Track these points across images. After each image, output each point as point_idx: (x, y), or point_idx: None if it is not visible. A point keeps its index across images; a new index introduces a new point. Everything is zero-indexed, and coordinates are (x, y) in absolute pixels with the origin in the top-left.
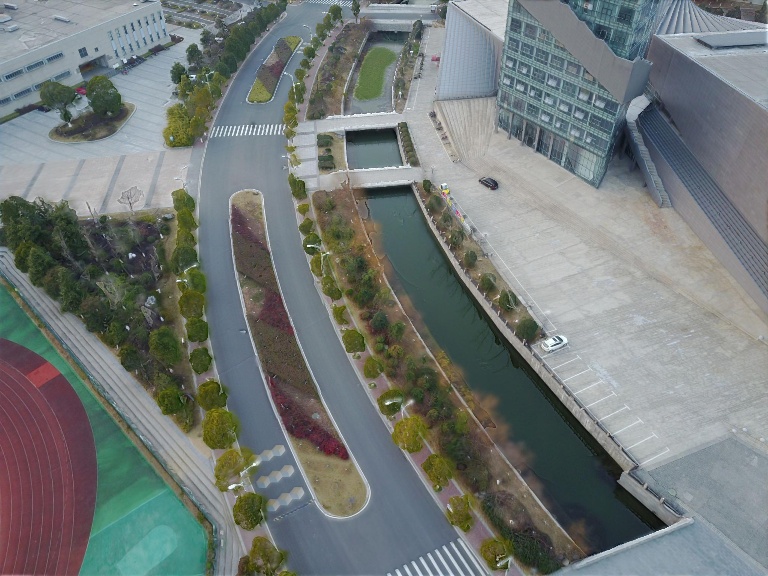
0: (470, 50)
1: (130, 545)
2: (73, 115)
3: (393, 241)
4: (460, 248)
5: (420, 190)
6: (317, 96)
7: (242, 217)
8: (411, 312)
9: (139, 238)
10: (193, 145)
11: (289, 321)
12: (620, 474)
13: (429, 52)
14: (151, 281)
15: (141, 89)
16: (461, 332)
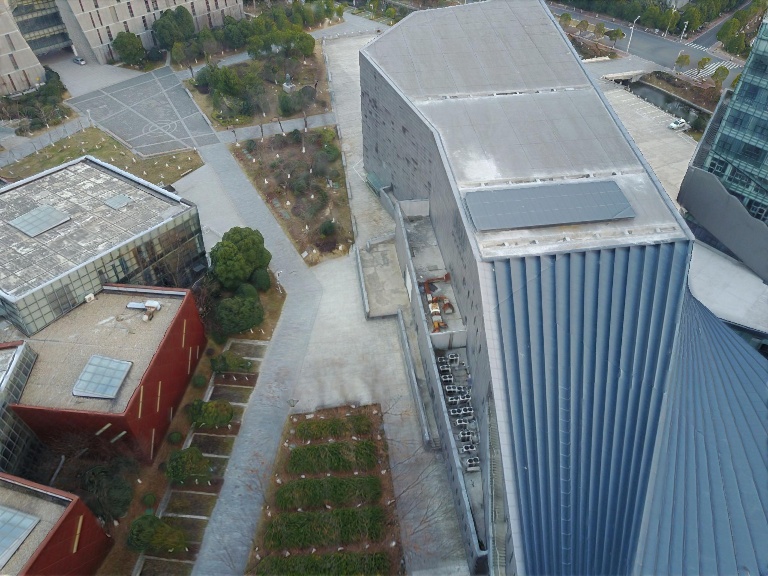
0: None
1: None
2: None
3: None
4: None
5: None
6: None
7: None
8: None
9: None
10: None
11: None
12: None
13: None
14: None
15: None
16: None
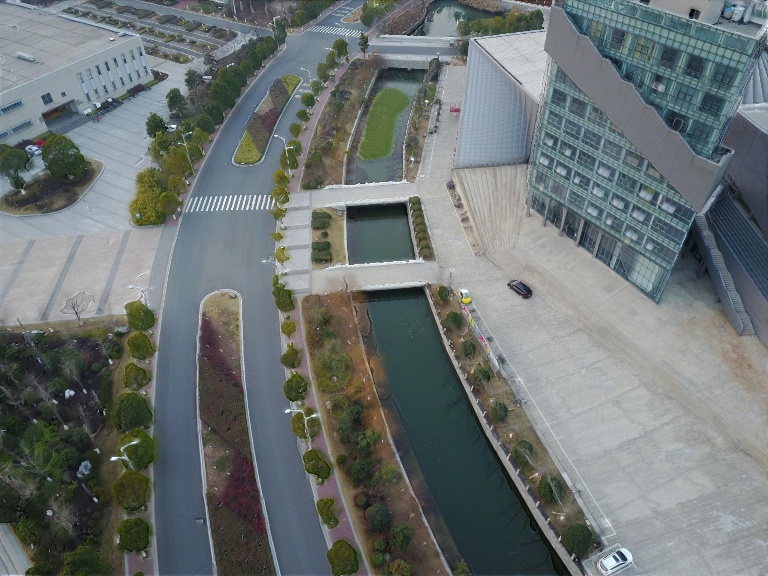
0: (496, 104)
1: None
2: (27, 181)
3: (400, 360)
4: (485, 390)
5: (435, 296)
6: (314, 160)
7: (213, 333)
8: (421, 489)
9: (80, 368)
10: (164, 223)
11: (261, 506)
12: None
13: (447, 98)
14: (87, 439)
15: (113, 142)
16: (485, 503)
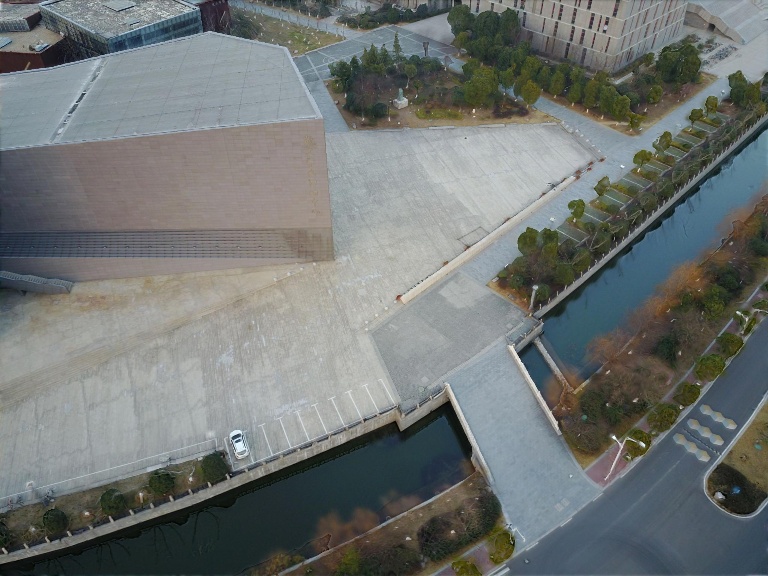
0: None
1: None
2: None
3: None
4: (14, 536)
5: None
6: None
7: None
8: None
9: None
10: None
11: None
12: (394, 427)
13: None
14: None
15: None
16: (141, 572)
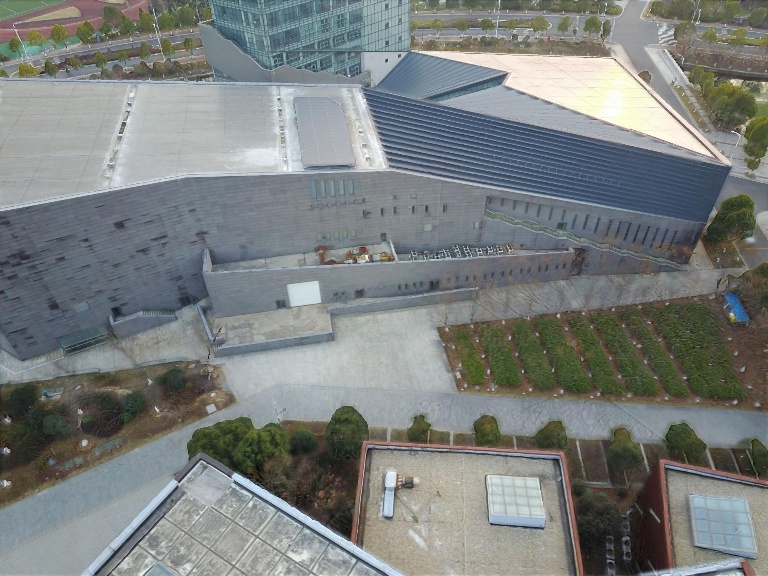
0: None
1: (40, 46)
2: None
3: None
4: None
5: None
6: None
7: None
8: None
9: None
10: None
11: None
12: None
13: None
14: None
15: None
16: None
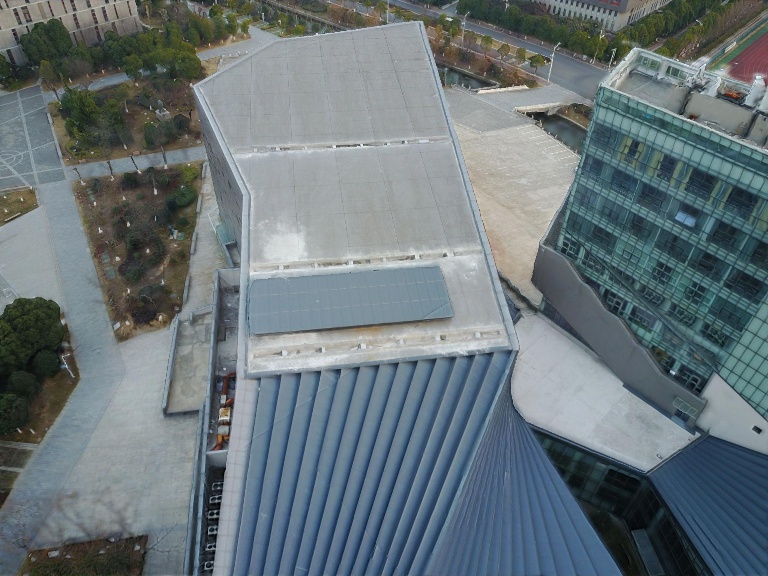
0: None
1: None
2: None
3: None
4: None
5: None
6: None
7: None
8: None
9: None
10: None
11: None
12: None
13: None
14: None
15: None
16: None
